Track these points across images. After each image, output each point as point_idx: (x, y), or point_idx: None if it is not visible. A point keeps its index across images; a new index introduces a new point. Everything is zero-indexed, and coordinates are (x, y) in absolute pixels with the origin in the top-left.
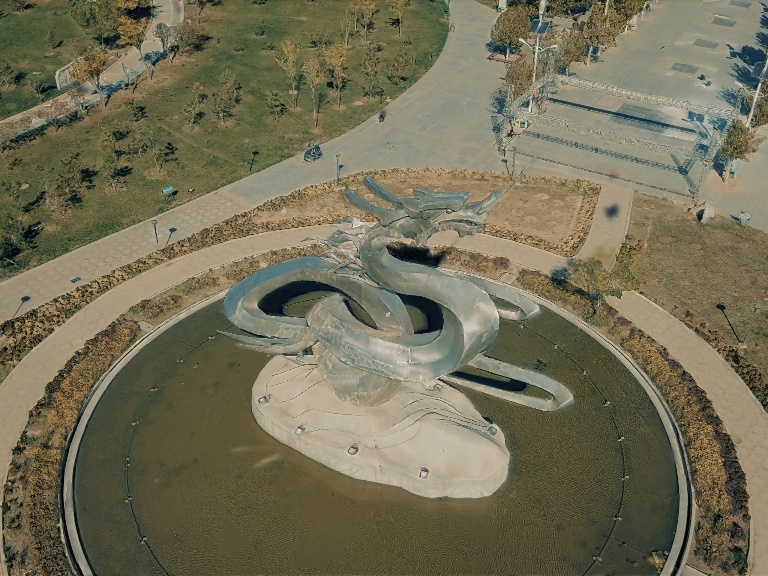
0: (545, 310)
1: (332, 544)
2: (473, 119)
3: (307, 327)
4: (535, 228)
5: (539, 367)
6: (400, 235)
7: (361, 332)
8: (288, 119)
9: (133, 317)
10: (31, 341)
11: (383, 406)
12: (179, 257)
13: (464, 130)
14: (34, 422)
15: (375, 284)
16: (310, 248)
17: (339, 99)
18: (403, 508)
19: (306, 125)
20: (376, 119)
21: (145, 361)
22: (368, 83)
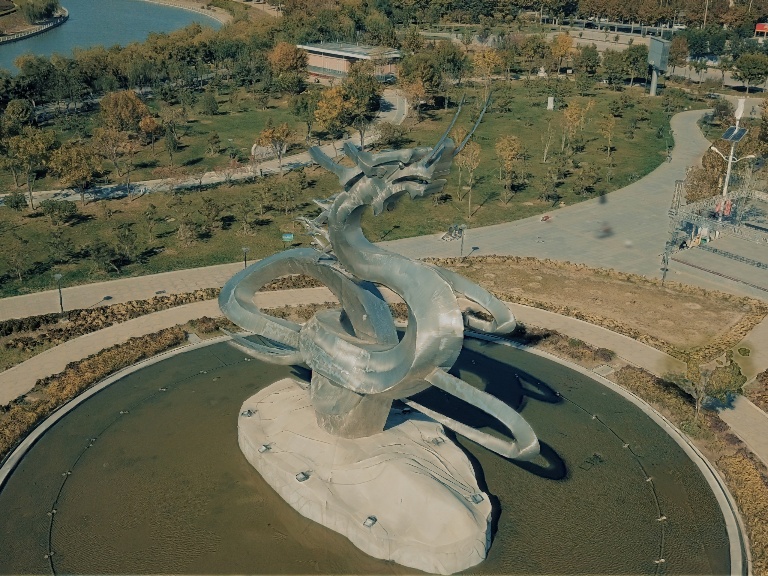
0: (633, 408)
1: (234, 572)
2: (648, 231)
3: (297, 332)
4: (666, 332)
5: (592, 461)
6: (360, 201)
7: (331, 332)
8: (447, 206)
9: (188, 329)
10: (86, 328)
11: (358, 440)
12: (265, 291)
13: (632, 238)
14: (38, 390)
15: (351, 275)
16: (395, 304)
17: (509, 198)
18: (352, 570)
19: (462, 213)
20: (539, 218)
21: (172, 365)
22: (543, 185)
